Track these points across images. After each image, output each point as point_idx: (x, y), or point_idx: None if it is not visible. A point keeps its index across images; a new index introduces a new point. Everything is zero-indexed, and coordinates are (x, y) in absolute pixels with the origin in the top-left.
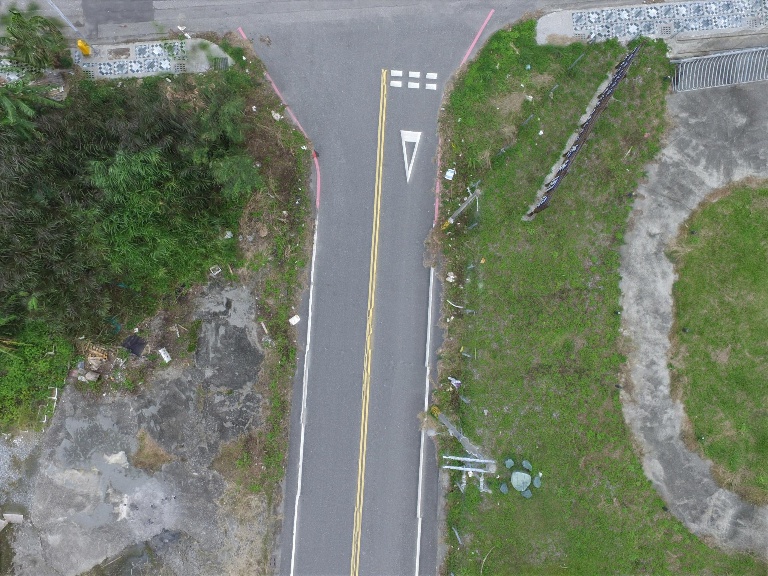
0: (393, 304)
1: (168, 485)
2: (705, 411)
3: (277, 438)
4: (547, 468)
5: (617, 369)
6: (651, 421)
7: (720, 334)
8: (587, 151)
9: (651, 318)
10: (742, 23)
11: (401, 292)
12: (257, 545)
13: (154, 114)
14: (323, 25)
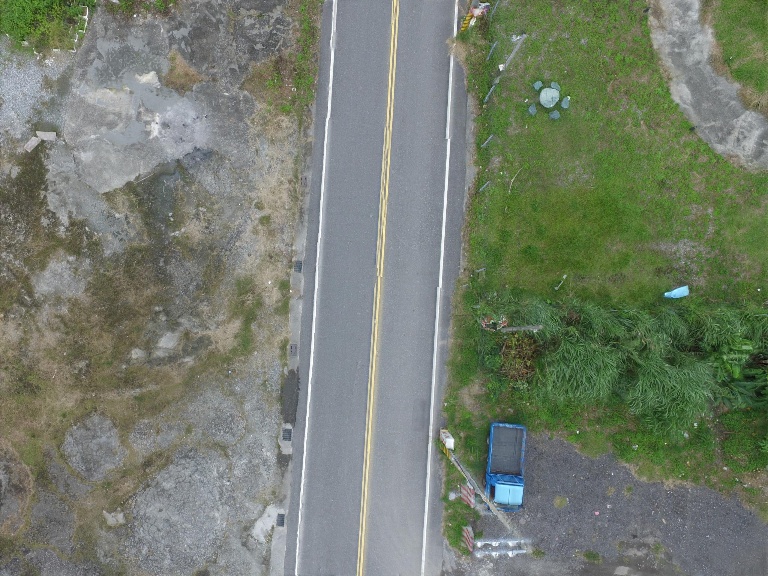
0: None
1: (199, 105)
2: (733, 34)
3: (307, 62)
4: (575, 92)
5: None
6: (679, 46)
7: None
8: None
9: None
10: None
11: None
12: (288, 165)
13: None
14: None
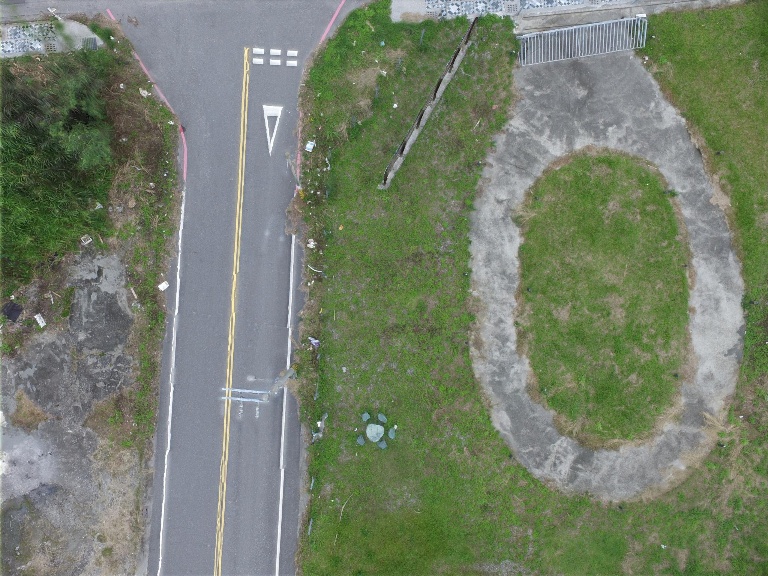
0: (257, 270)
1: (44, 442)
2: (548, 365)
3: (148, 397)
4: (402, 420)
5: (467, 327)
6: (499, 375)
7: (561, 293)
8: (439, 123)
9: (498, 279)
10: (584, 0)
11: (264, 258)
12: (129, 497)
13: (16, 91)
14: (188, 6)
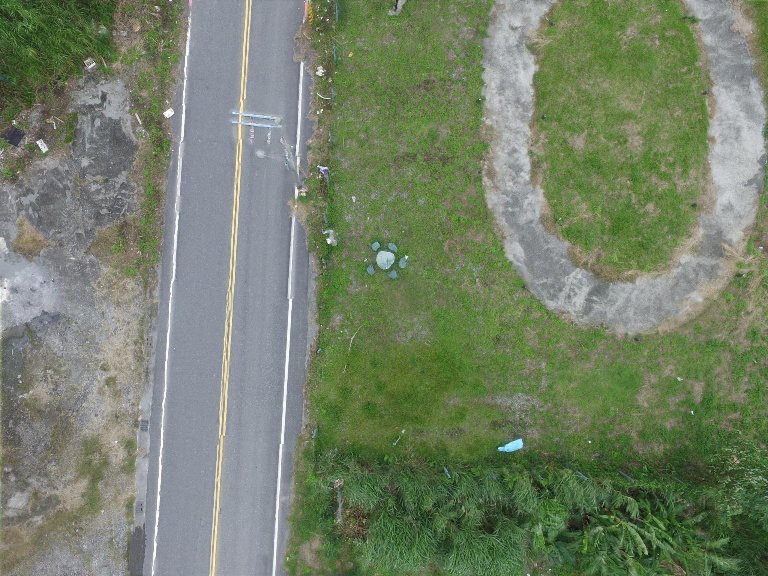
0: (264, 97)
1: (46, 269)
2: (563, 194)
3: (152, 225)
4: (413, 251)
5: (480, 156)
6: (512, 206)
7: (577, 120)
8: None
9: (512, 107)
10: None
11: (272, 86)
12: (134, 326)
13: None
14: None
